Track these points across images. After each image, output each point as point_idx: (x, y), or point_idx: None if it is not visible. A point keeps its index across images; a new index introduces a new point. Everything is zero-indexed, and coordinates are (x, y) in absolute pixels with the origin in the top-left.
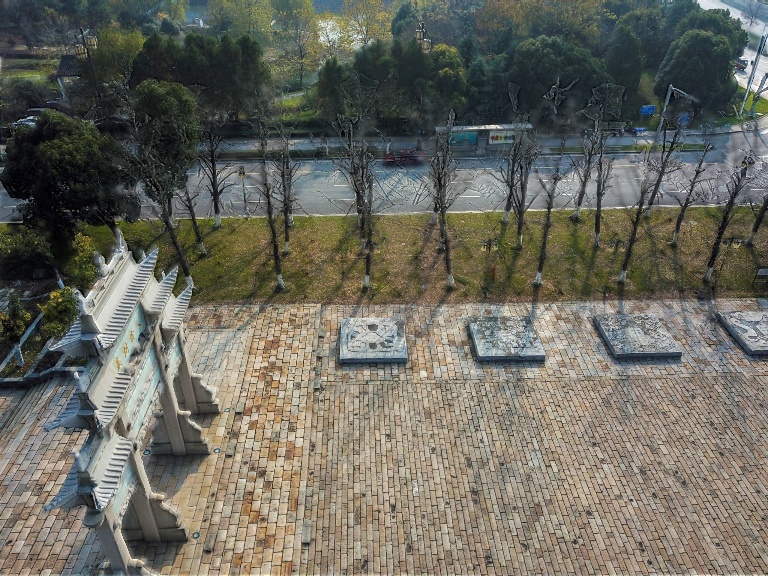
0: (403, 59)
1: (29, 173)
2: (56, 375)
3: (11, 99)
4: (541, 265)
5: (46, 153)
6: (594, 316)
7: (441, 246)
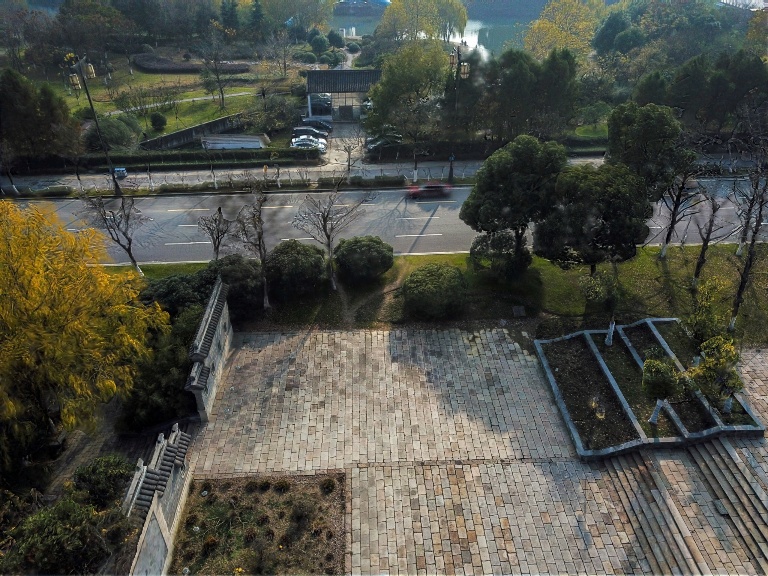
0: (730, 72)
1: (522, 205)
2: (722, 435)
3: (286, 118)
4: None
5: (577, 185)
6: None
7: None
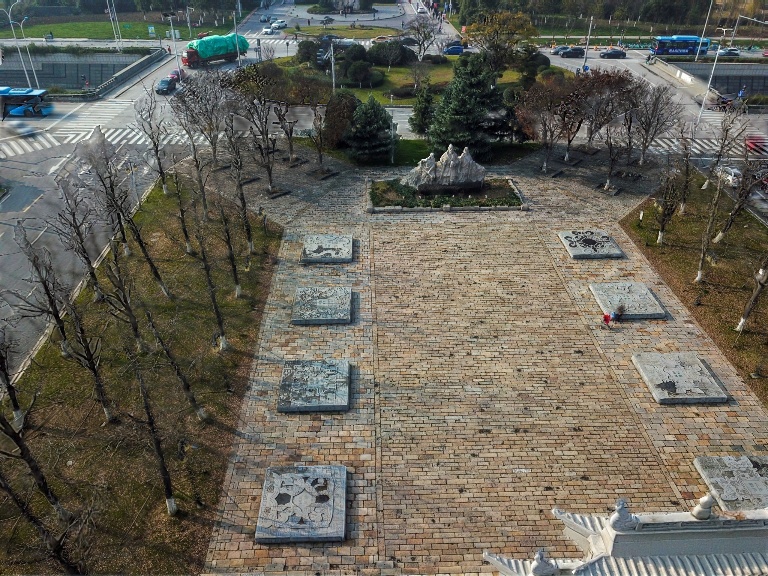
0: None
1: None
2: None
3: None
4: (222, 328)
5: None
6: (291, 321)
7: (110, 417)
